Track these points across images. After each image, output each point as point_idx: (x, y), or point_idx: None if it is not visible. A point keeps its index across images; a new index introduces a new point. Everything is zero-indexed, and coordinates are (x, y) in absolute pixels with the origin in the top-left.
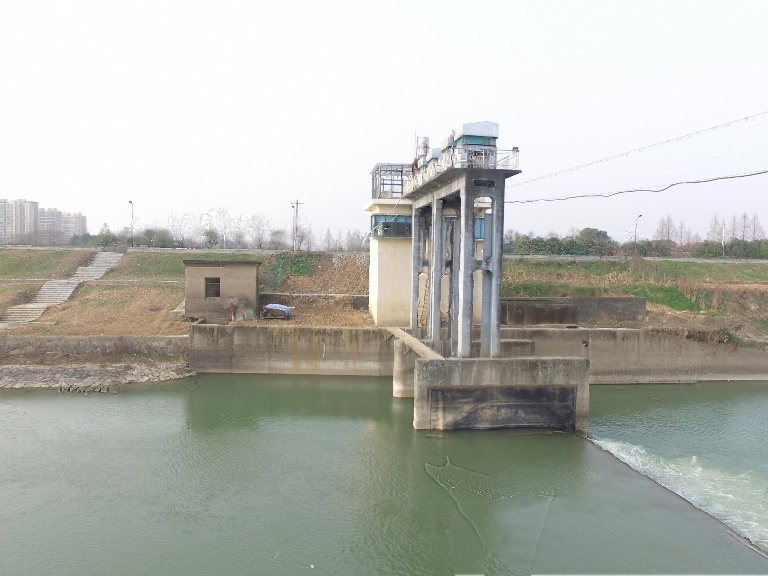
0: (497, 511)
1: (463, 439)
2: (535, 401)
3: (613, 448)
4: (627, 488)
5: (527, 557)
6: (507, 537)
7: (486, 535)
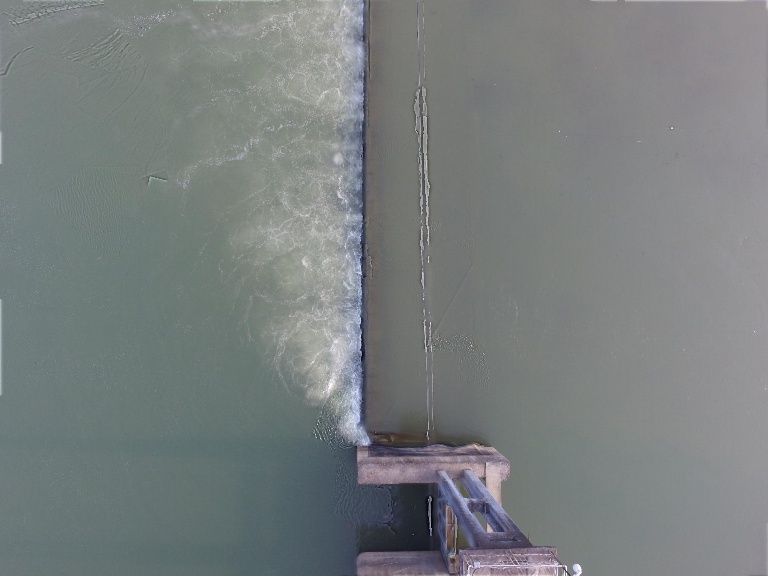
0: (470, 319)
1: (456, 442)
2: (404, 453)
3: (347, 427)
4: (386, 342)
5: (471, 274)
6: (473, 293)
7: (482, 296)
